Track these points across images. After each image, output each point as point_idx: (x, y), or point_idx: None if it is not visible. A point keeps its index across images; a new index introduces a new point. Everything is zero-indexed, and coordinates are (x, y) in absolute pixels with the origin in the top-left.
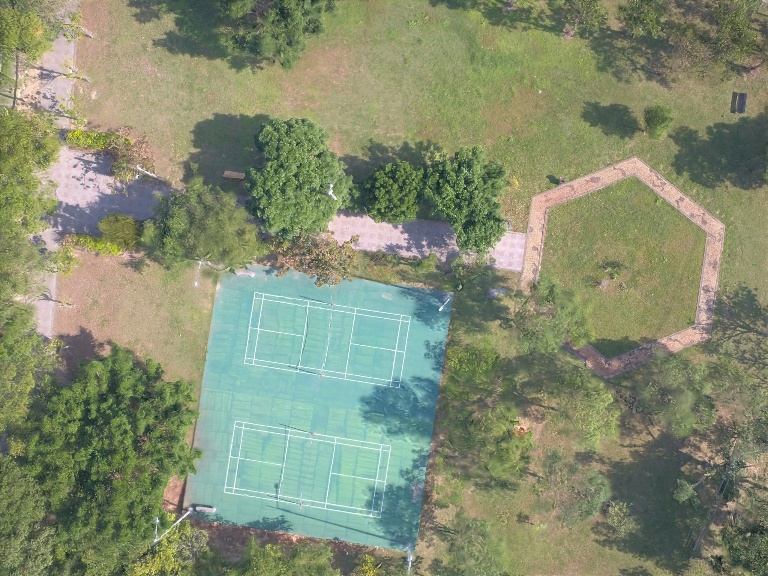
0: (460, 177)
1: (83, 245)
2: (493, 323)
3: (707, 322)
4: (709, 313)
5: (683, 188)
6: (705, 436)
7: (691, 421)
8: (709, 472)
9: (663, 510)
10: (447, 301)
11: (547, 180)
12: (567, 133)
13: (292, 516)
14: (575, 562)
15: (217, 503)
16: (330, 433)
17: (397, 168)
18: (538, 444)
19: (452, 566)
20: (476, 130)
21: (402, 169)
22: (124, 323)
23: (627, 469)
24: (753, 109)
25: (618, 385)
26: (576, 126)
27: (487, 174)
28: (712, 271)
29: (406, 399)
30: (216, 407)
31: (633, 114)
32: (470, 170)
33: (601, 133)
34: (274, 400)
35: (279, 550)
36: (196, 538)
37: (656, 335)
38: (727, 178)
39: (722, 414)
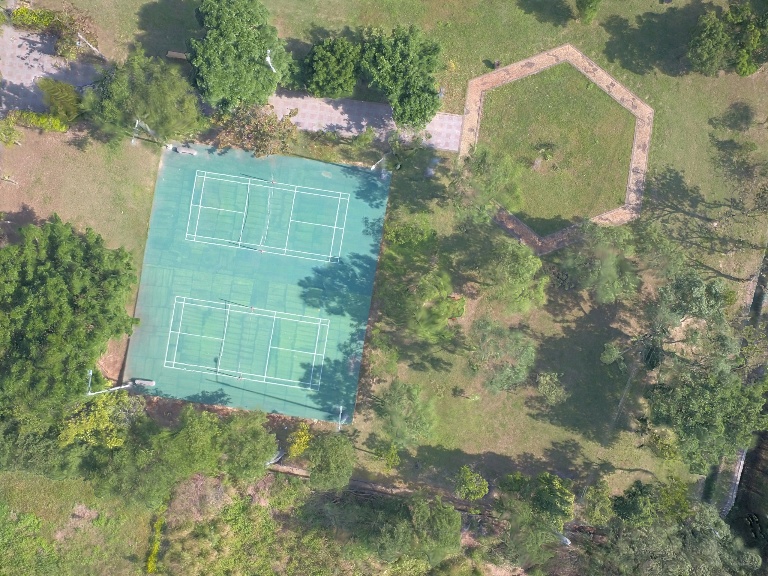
0: (396, 51)
1: (26, 119)
2: (430, 201)
3: (637, 202)
4: (639, 194)
5: (614, 74)
6: (635, 312)
7: (613, 275)
8: (635, 337)
9: (595, 384)
10: (379, 161)
11: (483, 65)
12: (502, 20)
13: (231, 389)
14: (509, 435)
15: (157, 377)
16: (270, 308)
17: (335, 42)
18: (473, 319)
19: (389, 440)
20: (415, 16)
21: (339, 43)
22: (66, 200)
23: (560, 344)
24: (680, 0)
25: (551, 262)
26: (511, 13)
27: (423, 52)
28: (641, 154)
29: (345, 275)
30: (157, 283)
31: (566, 3)
32: (406, 45)
33: (535, 20)
34: (215, 275)
35: (216, 416)
36: (133, 404)
37: (588, 214)
38: (656, 65)
39: (651, 291)
